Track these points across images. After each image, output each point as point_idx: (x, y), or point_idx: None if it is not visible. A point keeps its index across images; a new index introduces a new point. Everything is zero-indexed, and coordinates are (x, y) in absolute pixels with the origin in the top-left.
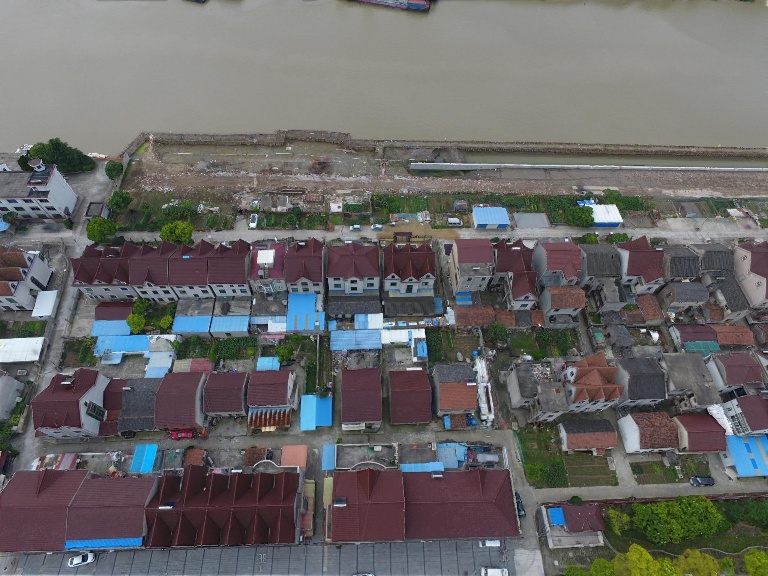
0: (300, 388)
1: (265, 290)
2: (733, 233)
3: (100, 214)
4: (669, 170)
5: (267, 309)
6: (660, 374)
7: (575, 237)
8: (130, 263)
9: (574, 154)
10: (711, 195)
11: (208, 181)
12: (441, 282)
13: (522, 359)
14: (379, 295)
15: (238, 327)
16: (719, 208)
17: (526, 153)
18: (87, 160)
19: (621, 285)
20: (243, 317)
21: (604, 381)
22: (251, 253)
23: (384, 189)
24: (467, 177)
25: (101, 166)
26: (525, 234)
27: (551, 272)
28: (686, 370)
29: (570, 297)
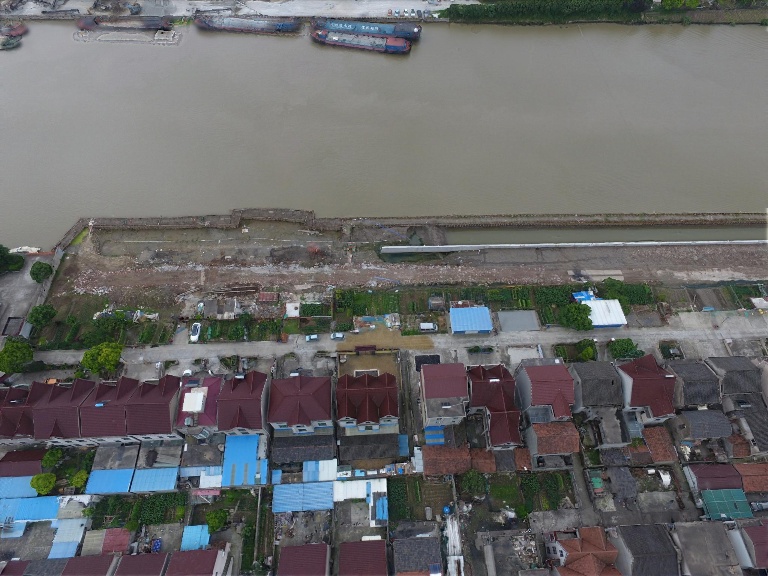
0: (235, 563)
1: (196, 437)
2: (759, 331)
3: (18, 332)
4: (682, 245)
5: (200, 457)
6: (672, 554)
7: (570, 343)
8: (34, 414)
9: (571, 227)
10: (732, 277)
11: (149, 278)
12: (409, 409)
13: (504, 515)
14: (334, 433)
15: (164, 484)
16: (742, 296)
17: (515, 227)
18: (13, 260)
19: (624, 418)
20: (171, 469)
21: (601, 566)
22: (180, 391)
23: (349, 282)
24: (446, 261)
25: (31, 263)
26: (511, 340)
27: (538, 406)
28: (704, 548)
29: (561, 440)
